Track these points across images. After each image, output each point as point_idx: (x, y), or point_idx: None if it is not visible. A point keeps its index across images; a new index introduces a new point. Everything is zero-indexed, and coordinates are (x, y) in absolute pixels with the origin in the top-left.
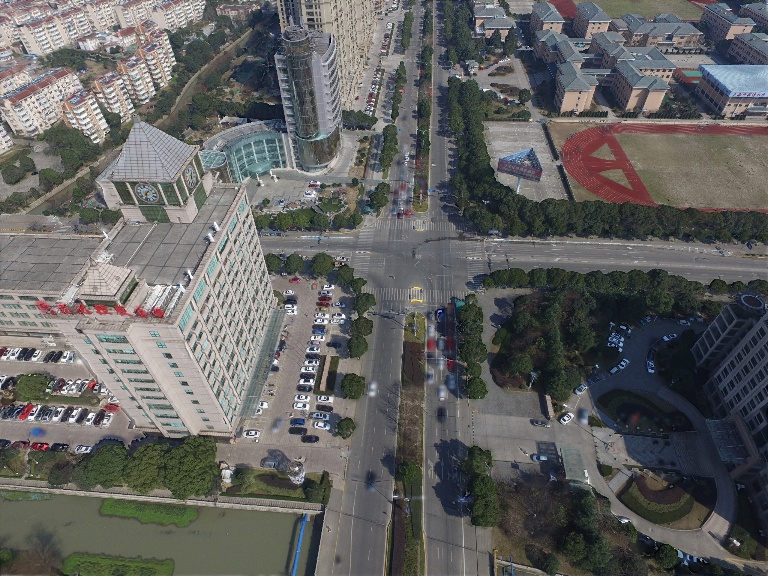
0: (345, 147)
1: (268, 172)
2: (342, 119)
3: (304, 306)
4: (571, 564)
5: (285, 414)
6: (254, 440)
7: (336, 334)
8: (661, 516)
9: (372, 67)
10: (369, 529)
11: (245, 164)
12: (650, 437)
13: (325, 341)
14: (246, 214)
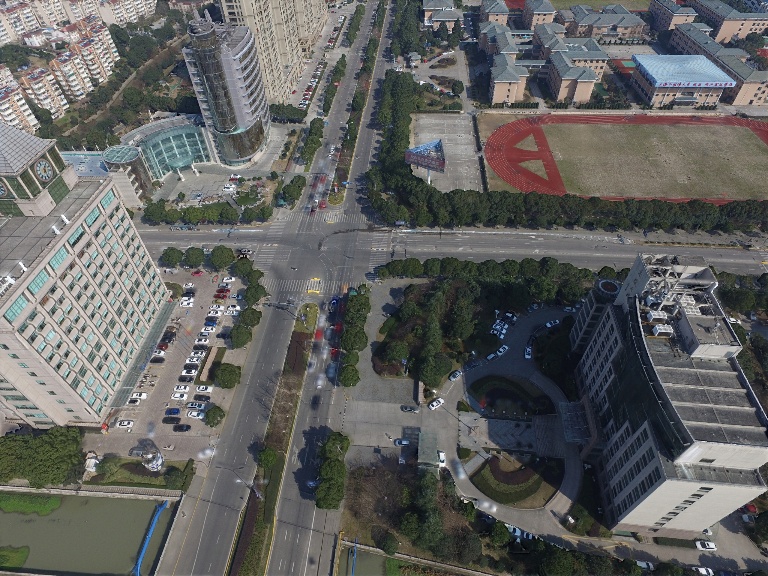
0: (273, 141)
1: (191, 166)
2: (271, 113)
3: (201, 298)
4: (413, 544)
5: (162, 404)
6: (126, 430)
7: (228, 325)
8: (507, 496)
9: (315, 60)
10: (223, 514)
11: (165, 159)
12: (514, 421)
13: (215, 332)
14: (114, 207)
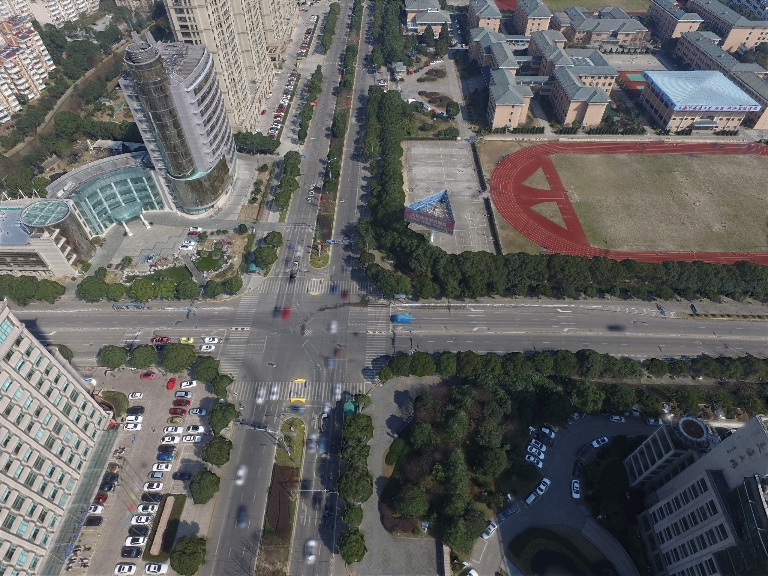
0: (240, 178)
1: (140, 216)
2: (237, 143)
3: (153, 415)
4: None
5: None
6: None
7: (188, 458)
8: None
9: (287, 71)
10: None
11: (107, 209)
12: None
13: (171, 470)
14: (13, 341)
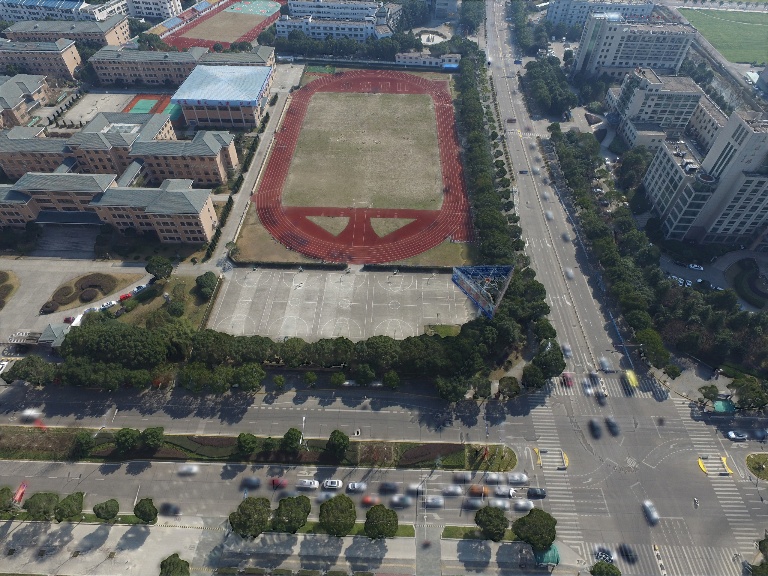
0: None
1: None
2: None
3: None
4: None
5: None
6: None
7: None
8: None
9: None
10: None
11: None
12: None
13: None
14: None
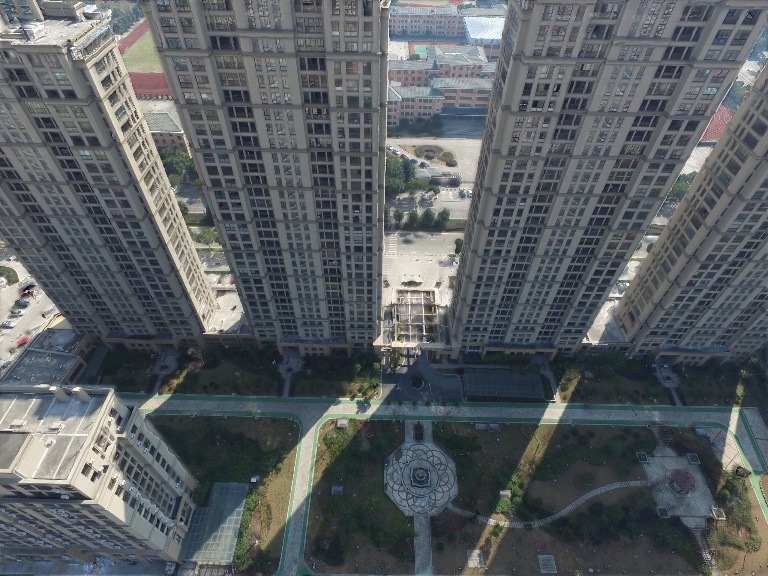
0: None
1: None
2: None
3: None
4: None
5: None
6: None
7: None
8: None
9: (444, 295)
10: None
11: None
12: None
13: None
14: None
